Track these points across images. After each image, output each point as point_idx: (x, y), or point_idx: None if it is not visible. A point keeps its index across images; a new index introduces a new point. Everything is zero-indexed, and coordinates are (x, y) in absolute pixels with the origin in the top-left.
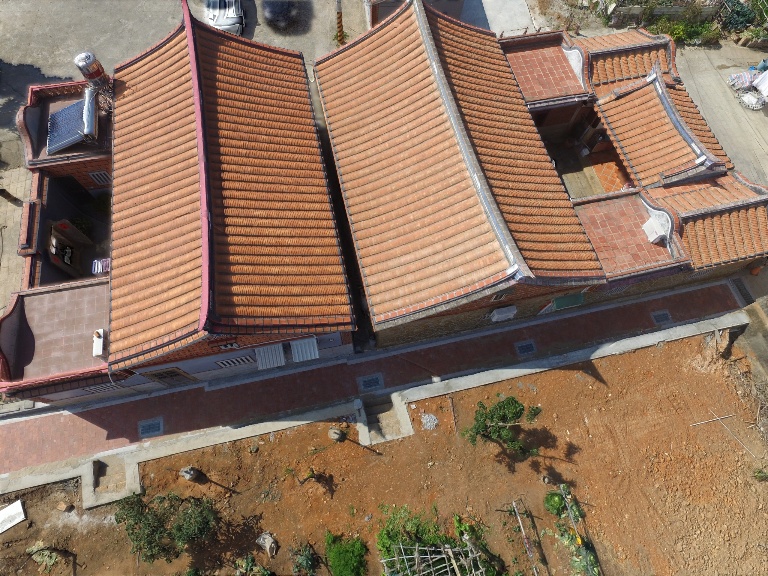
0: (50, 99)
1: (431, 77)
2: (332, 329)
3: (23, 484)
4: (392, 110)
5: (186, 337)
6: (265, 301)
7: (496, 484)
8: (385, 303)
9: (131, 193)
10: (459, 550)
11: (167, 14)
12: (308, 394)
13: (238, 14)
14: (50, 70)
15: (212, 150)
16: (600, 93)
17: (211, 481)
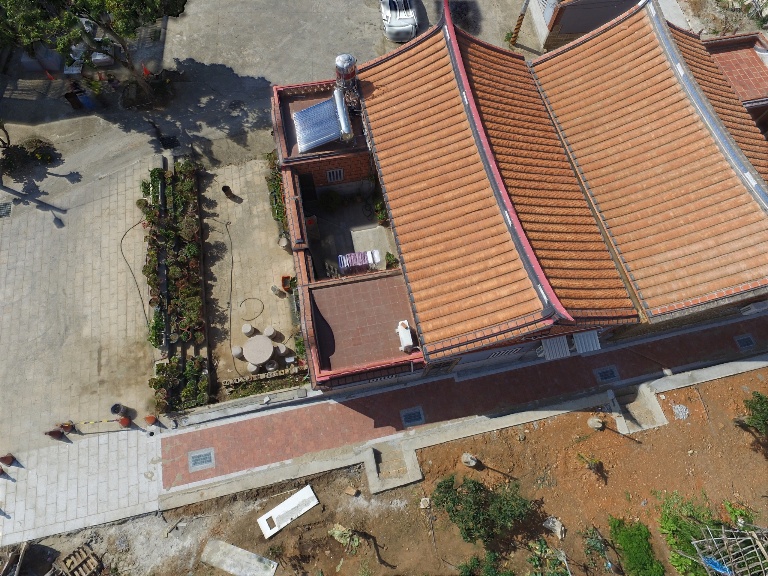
0: (288, 99)
1: (673, 79)
2: (623, 321)
3: (312, 469)
4: (629, 110)
5: (520, 328)
6: (575, 294)
7: (756, 471)
8: (658, 297)
9: (407, 190)
10: (762, 532)
11: (342, 15)
12: (551, 385)
13: (409, 15)
14: (242, 70)
15: None
16: None
17: (487, 467)
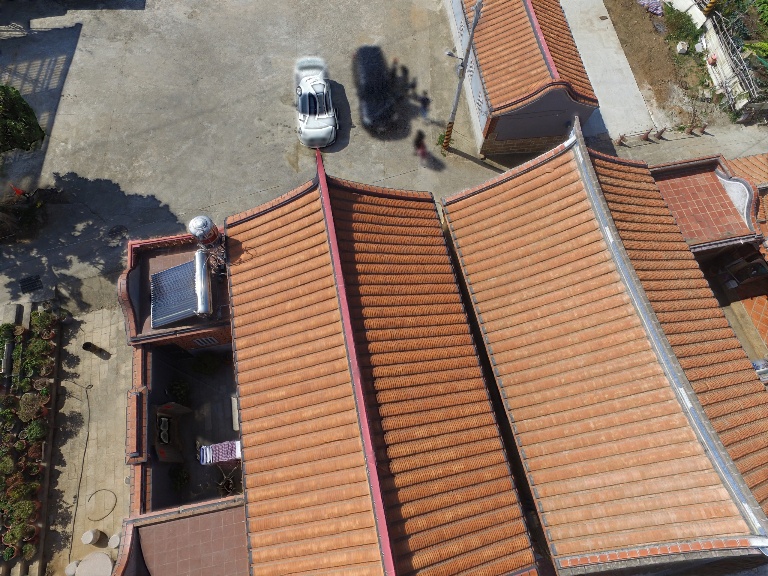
0: (149, 253)
1: (602, 243)
2: None
3: None
4: (551, 277)
5: None
6: (448, 571)
7: None
8: (569, 540)
9: (262, 398)
10: None
11: (253, 115)
12: None
13: (330, 114)
14: (130, 186)
15: (361, 351)
16: (766, 231)
17: None
